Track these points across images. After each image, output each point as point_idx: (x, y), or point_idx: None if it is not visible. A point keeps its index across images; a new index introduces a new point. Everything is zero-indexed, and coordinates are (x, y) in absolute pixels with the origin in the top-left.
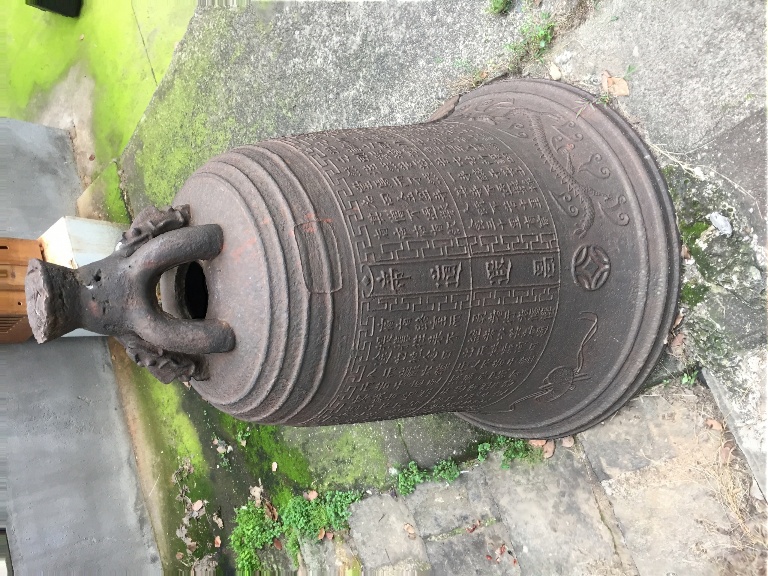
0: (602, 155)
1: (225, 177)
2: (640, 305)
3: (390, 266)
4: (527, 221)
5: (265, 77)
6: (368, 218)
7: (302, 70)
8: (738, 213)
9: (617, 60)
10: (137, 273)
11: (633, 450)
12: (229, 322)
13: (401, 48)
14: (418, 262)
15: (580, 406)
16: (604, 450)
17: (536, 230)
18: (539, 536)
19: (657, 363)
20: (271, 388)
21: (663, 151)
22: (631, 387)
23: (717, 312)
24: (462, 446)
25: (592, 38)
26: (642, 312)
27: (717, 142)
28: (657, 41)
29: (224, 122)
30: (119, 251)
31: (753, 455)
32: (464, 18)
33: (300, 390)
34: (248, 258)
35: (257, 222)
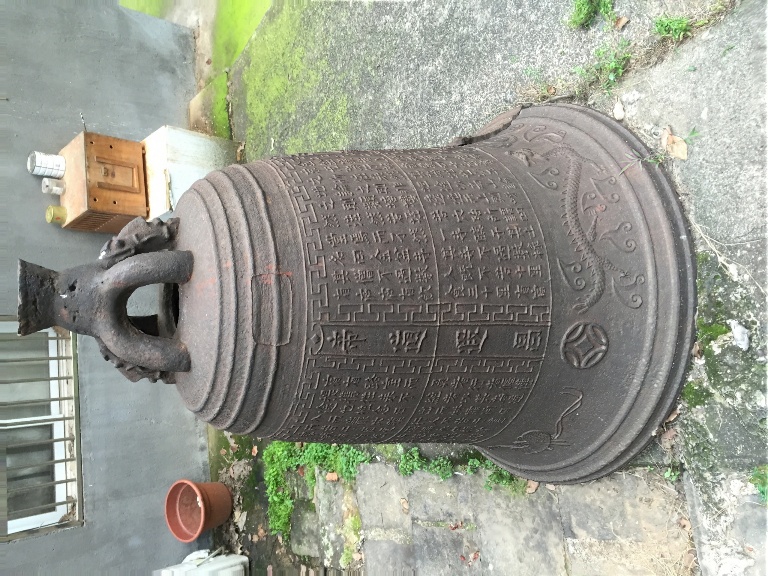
0: (633, 225)
1: (208, 205)
2: (633, 392)
3: (344, 327)
4: (519, 291)
5: (359, 27)
6: (332, 276)
7: (391, 30)
8: (761, 329)
9: (683, 117)
10: (107, 290)
11: (603, 520)
12: (188, 346)
13: (483, 35)
14: (377, 326)
15: (557, 465)
16: (576, 510)
17: (527, 301)
18: (505, 560)
19: (642, 450)
20: (217, 413)
21: (704, 234)
22: (611, 464)
23: (714, 422)
24: (459, 451)
25: (664, 84)
26: (633, 400)
27: (761, 244)
28: (729, 108)
29: (318, 62)
30: (102, 260)
31: (709, 575)
32: (547, 20)
33: (244, 420)
34: (208, 296)
35: (220, 264)
